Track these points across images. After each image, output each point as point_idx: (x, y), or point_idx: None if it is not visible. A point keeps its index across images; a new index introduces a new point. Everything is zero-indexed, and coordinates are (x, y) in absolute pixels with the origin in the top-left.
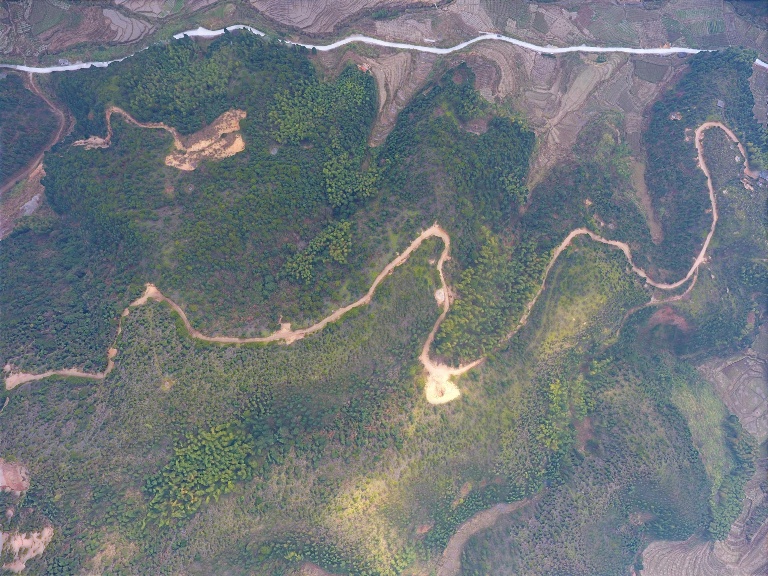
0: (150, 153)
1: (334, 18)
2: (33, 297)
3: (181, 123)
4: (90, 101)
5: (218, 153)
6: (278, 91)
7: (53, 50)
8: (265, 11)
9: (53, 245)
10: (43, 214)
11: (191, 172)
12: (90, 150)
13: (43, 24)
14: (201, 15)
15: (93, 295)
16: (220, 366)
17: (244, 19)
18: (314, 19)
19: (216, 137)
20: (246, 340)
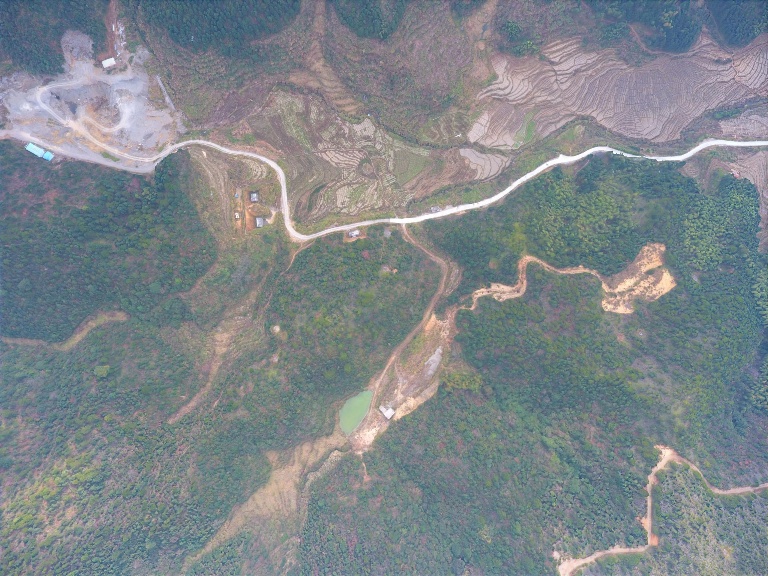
0: (593, 303)
1: (679, 124)
2: (528, 470)
3: (601, 264)
4: (499, 252)
5: (649, 291)
6: (685, 217)
7: (420, 198)
8: (613, 127)
9: (496, 404)
10: (454, 367)
11: (636, 316)
12: (513, 303)
13: (408, 174)
14: (553, 141)
15: (590, 460)
16: (761, 523)
17: (594, 138)
18: (661, 128)
19: (640, 274)
20: (757, 487)
